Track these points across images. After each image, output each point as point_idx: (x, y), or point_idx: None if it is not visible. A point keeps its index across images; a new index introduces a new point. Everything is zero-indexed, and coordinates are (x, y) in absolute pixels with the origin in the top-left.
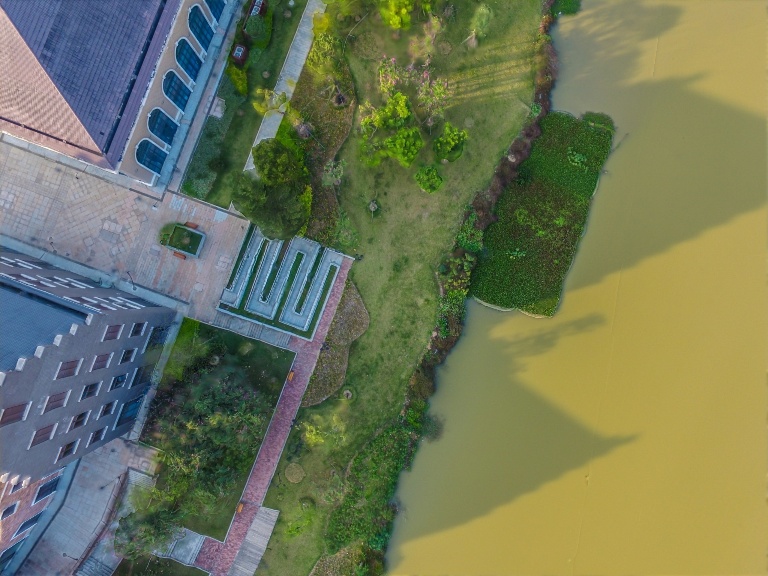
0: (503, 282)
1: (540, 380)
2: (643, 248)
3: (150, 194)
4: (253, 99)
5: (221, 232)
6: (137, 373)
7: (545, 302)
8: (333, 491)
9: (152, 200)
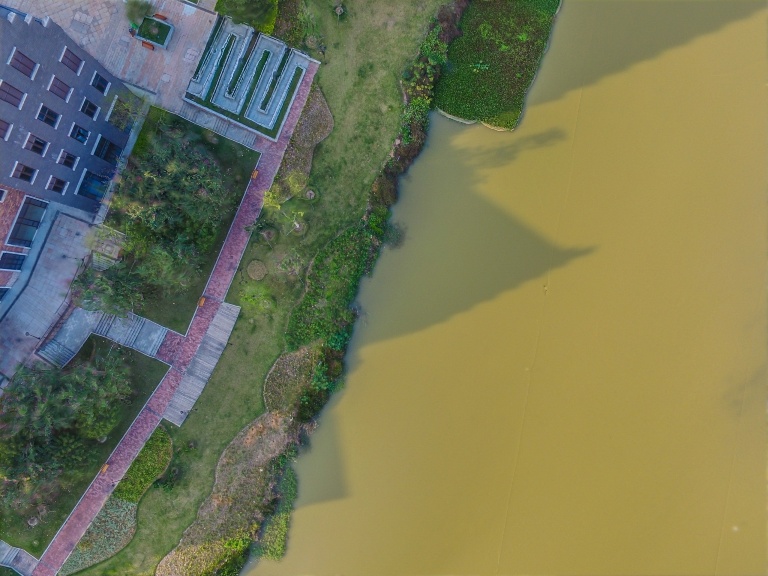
0: (466, 94)
1: (501, 192)
2: (605, 66)
3: None
4: None
5: (189, 25)
6: (101, 142)
7: (507, 115)
8: (289, 259)
9: None
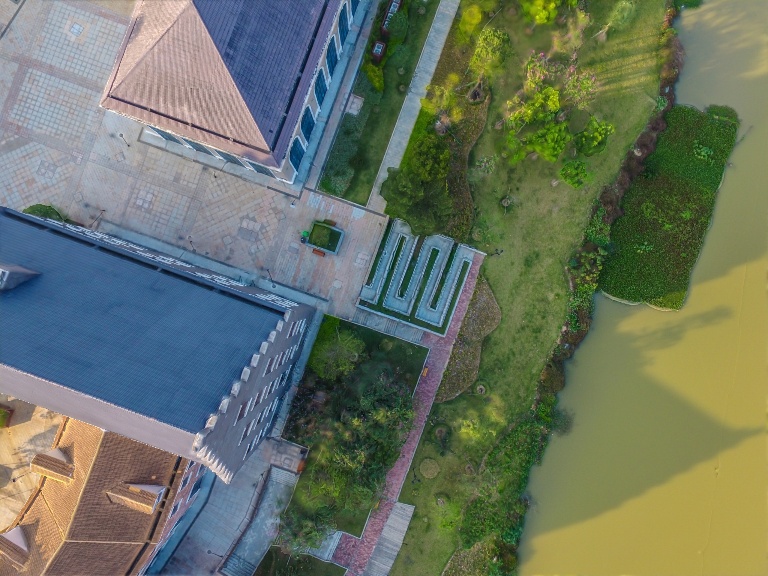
0: (631, 276)
1: (668, 373)
2: None
3: (288, 192)
4: (389, 96)
5: (359, 229)
6: None
7: (673, 295)
8: (487, 485)
9: (290, 198)
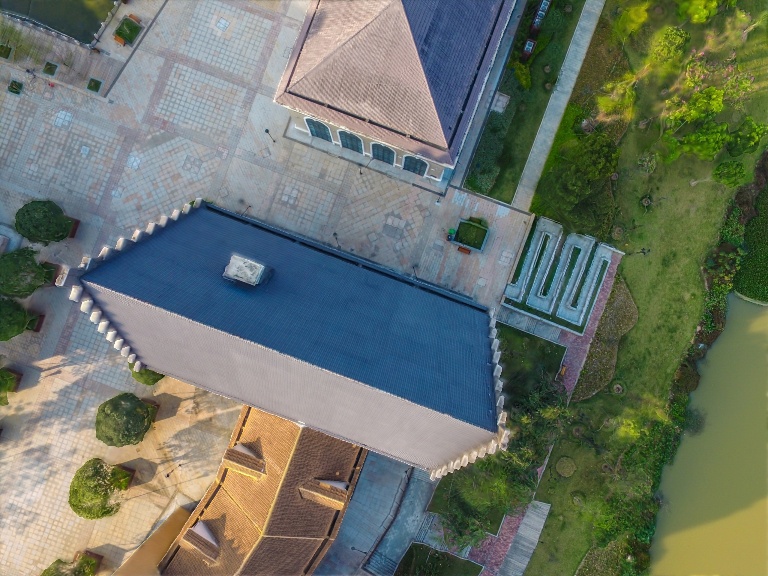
0: (764, 276)
1: None
2: None
3: (433, 189)
4: (535, 94)
5: (503, 227)
6: None
7: None
8: (643, 484)
9: (435, 195)
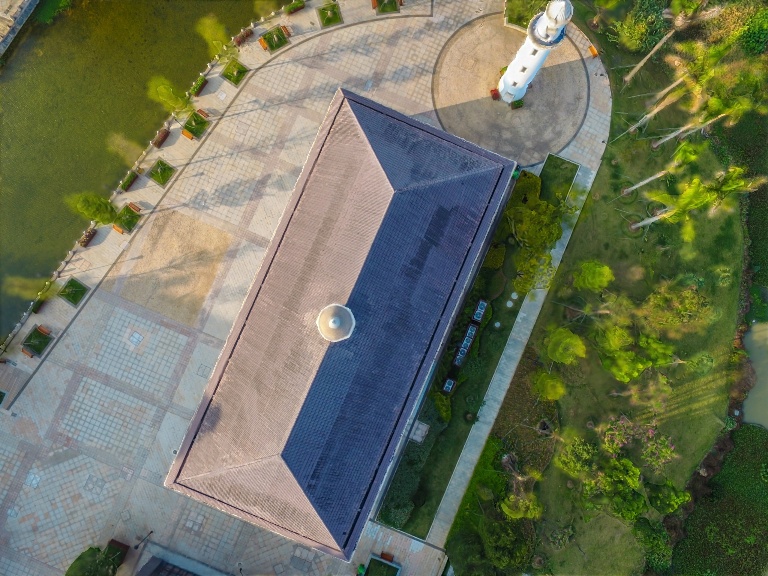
0: None
1: None
2: None
3: None
4: (455, 424)
5: (417, 563)
6: None
7: None
8: None
9: None
